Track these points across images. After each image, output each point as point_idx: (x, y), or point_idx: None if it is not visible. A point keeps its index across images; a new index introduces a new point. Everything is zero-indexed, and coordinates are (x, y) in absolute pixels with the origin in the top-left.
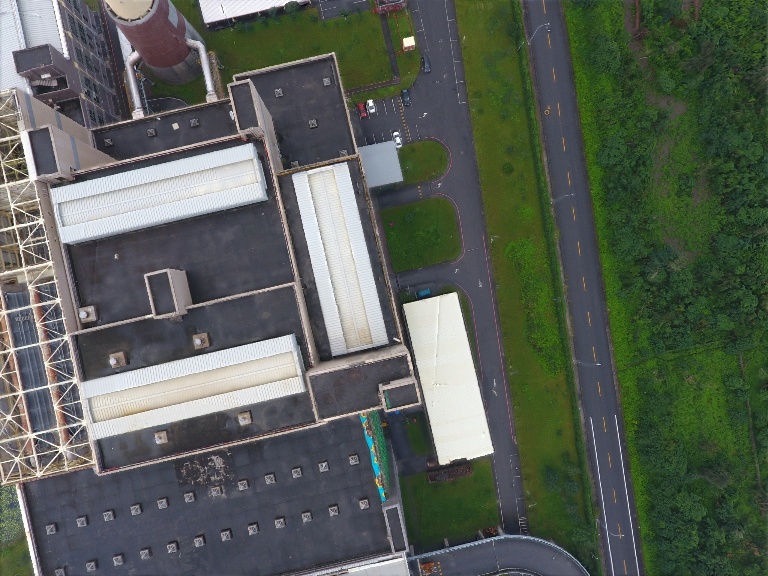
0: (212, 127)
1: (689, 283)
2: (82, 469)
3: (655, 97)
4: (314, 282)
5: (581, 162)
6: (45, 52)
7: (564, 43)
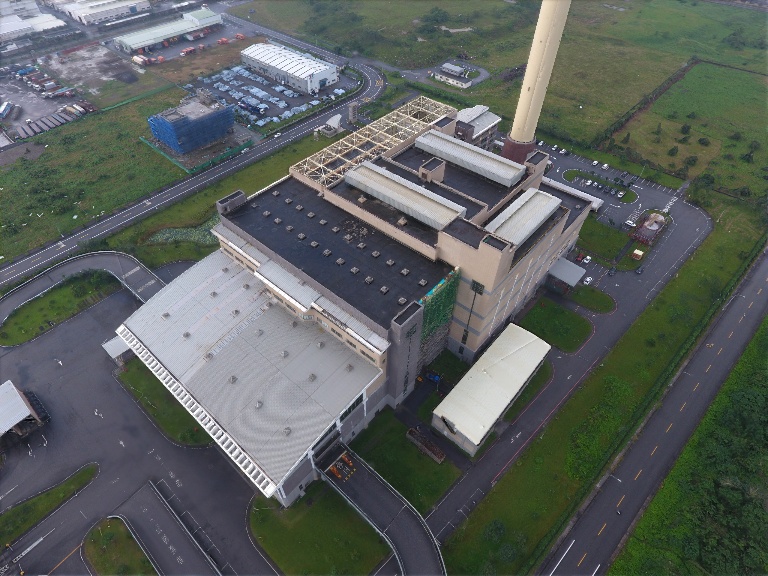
0: None
1: (763, 523)
2: (316, 190)
3: None
4: None
5: (715, 387)
6: (470, 127)
7: (753, 328)
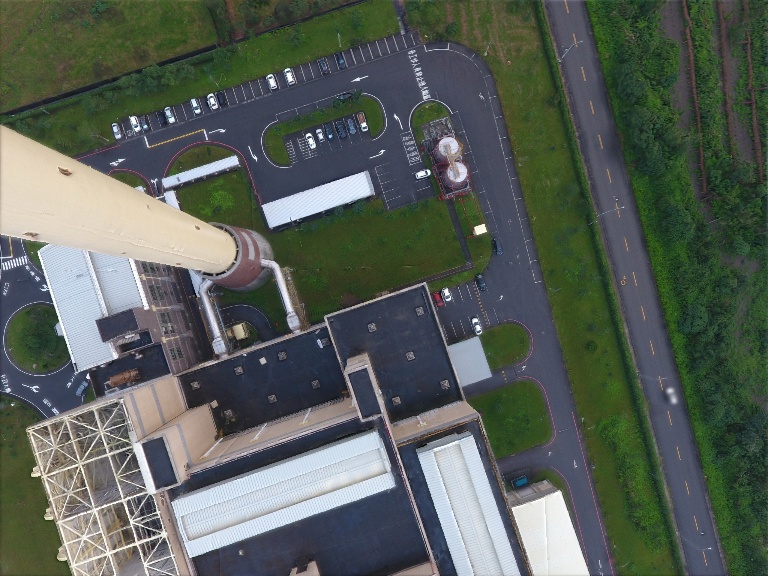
0: (301, 358)
1: None
2: None
3: (729, 258)
4: (446, 552)
5: (662, 330)
6: (129, 316)
7: (633, 211)
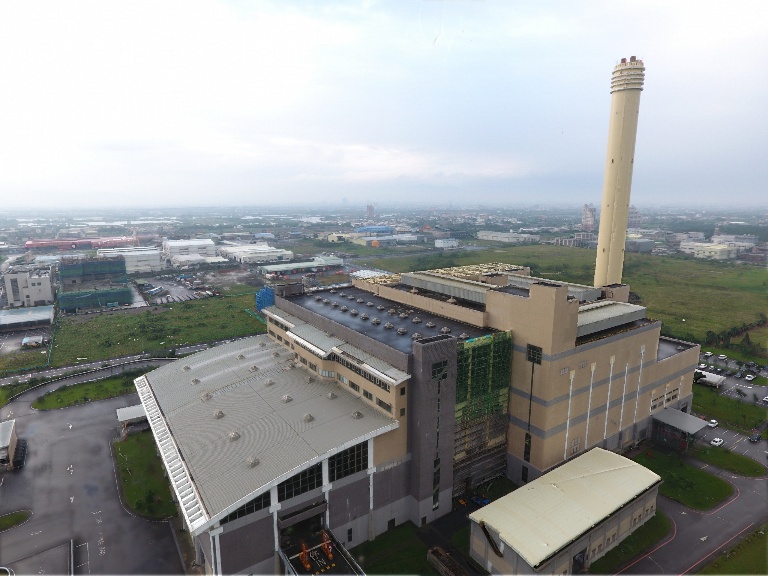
0: None
1: None
2: (372, 292)
3: None
4: None
5: None
6: None
7: None
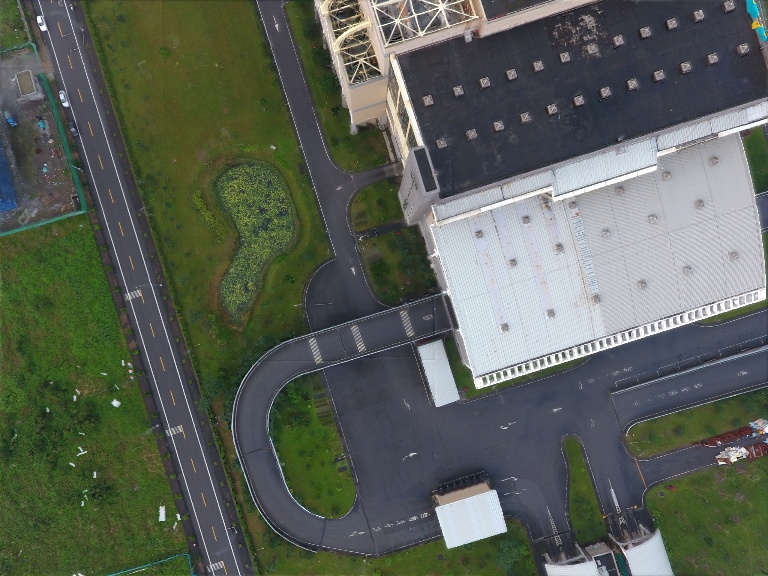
0: None
1: None
2: (454, 38)
3: None
4: None
5: None
6: None
7: None
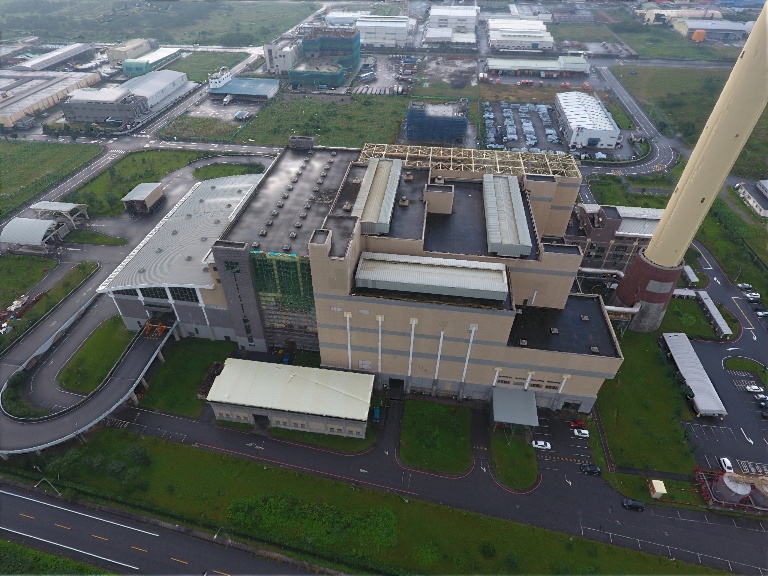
0: None
1: None
2: None
3: None
4: None
5: None
6: (616, 218)
7: None
